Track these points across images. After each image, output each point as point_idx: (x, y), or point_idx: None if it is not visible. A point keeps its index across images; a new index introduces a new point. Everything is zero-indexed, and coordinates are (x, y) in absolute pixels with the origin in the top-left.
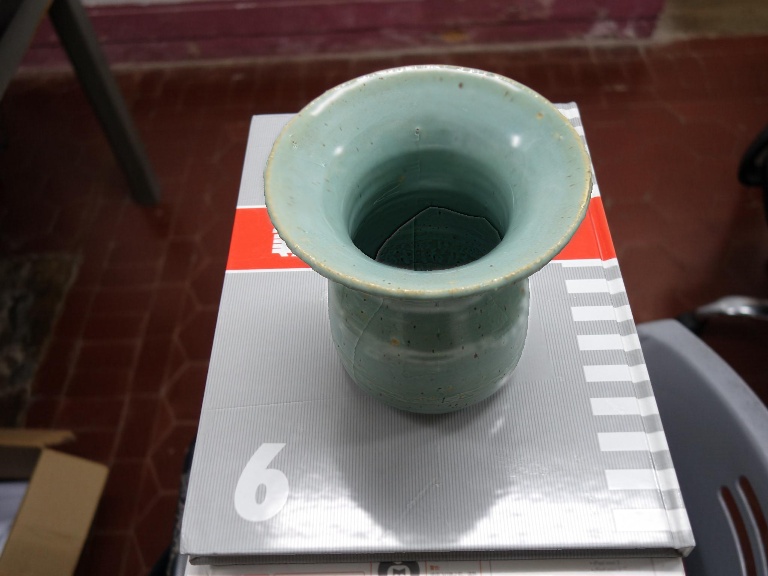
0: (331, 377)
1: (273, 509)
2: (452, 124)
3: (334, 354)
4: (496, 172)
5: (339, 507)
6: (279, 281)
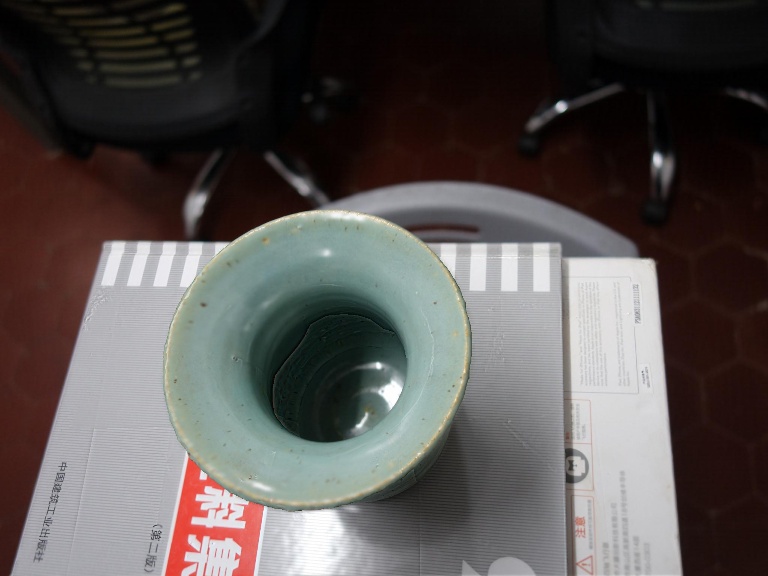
0: (396, 513)
1: (527, 572)
2: (238, 324)
3: (370, 509)
4: (296, 296)
5: (527, 509)
6: (271, 569)
